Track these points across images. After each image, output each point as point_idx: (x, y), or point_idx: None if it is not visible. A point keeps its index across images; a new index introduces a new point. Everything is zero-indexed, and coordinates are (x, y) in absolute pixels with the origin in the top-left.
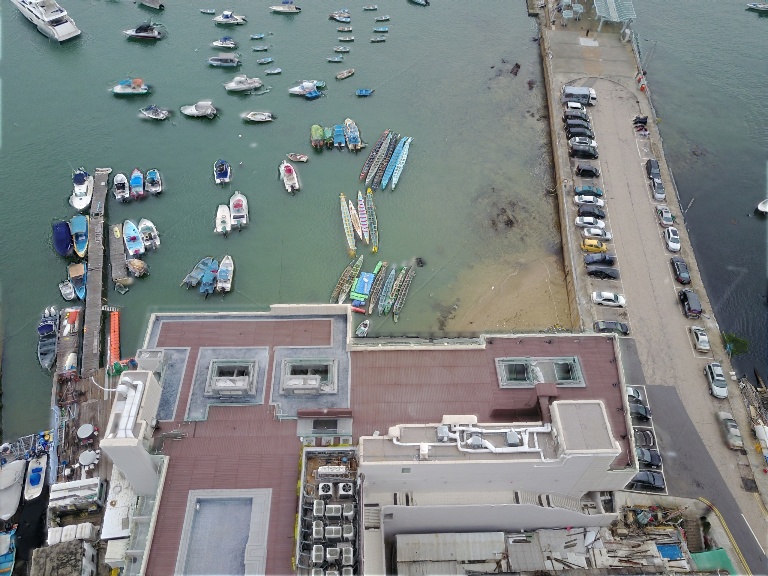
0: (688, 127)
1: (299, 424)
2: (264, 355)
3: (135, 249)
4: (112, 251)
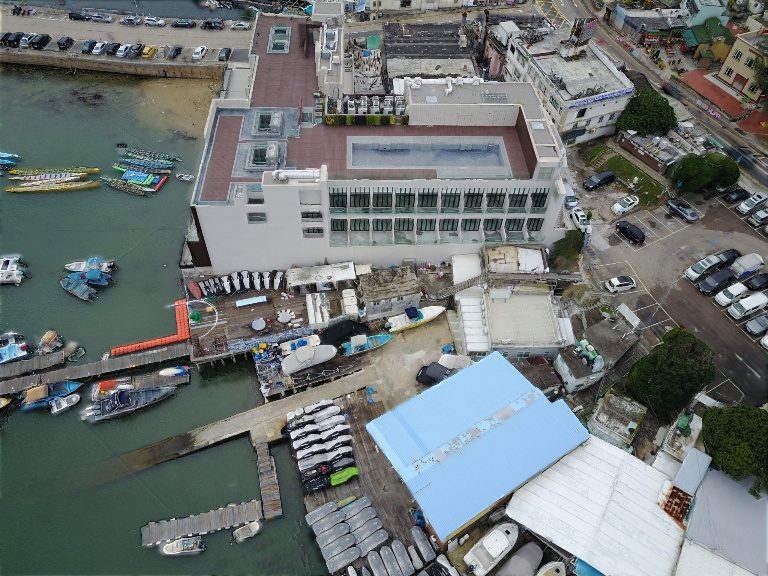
0: (29, 1)
1: (304, 127)
2: (245, 145)
3: (19, 350)
4: (12, 372)
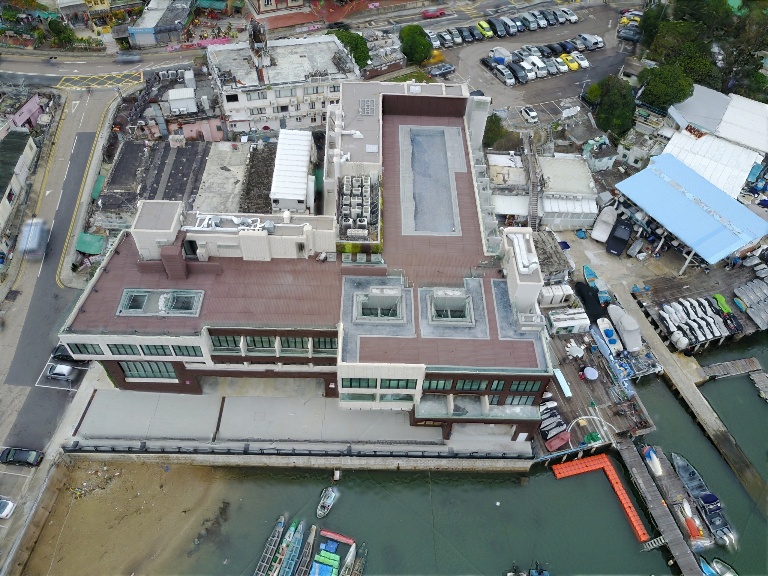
0: None
1: None
2: (425, 330)
3: None
4: None
